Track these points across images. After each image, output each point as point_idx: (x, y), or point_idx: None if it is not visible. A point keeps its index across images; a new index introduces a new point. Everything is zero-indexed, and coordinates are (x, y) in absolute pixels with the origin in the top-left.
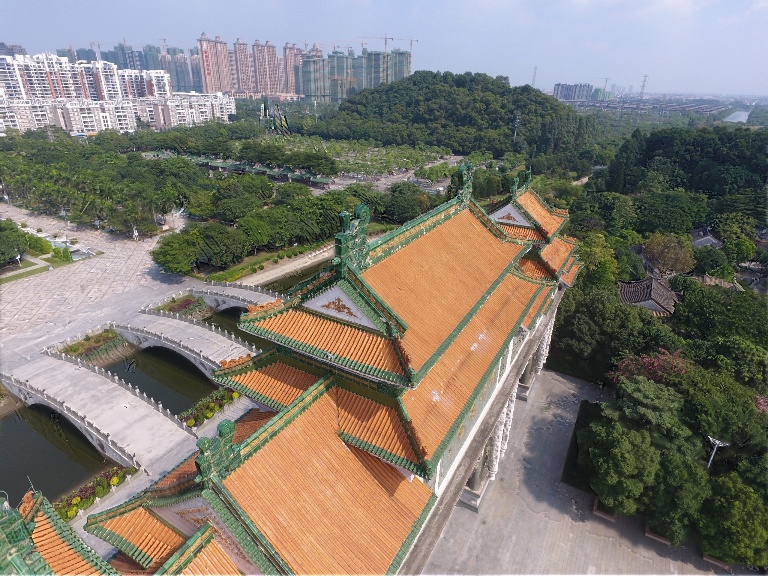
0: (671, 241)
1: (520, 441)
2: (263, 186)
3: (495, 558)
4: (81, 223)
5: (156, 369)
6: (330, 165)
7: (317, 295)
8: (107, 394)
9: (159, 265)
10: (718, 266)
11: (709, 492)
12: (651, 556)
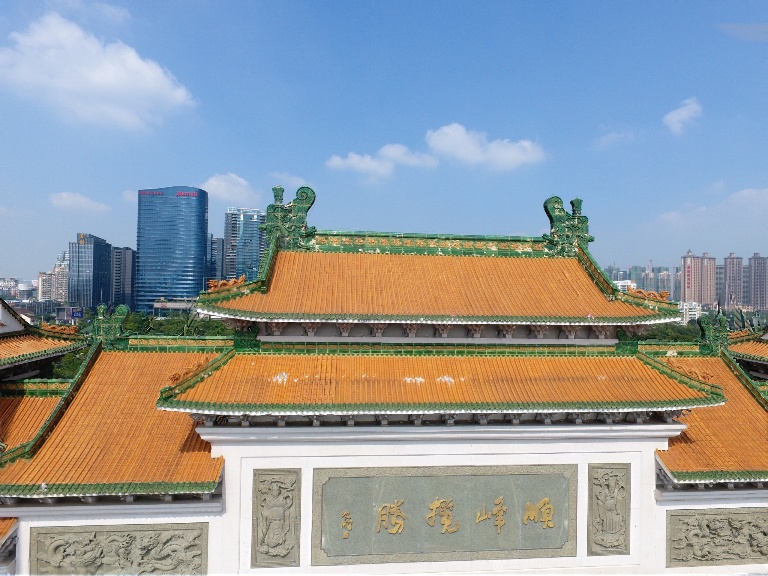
0: None
1: None
2: None
3: None
4: None
5: None
6: None
7: None
8: None
9: None
10: None
11: None
12: None
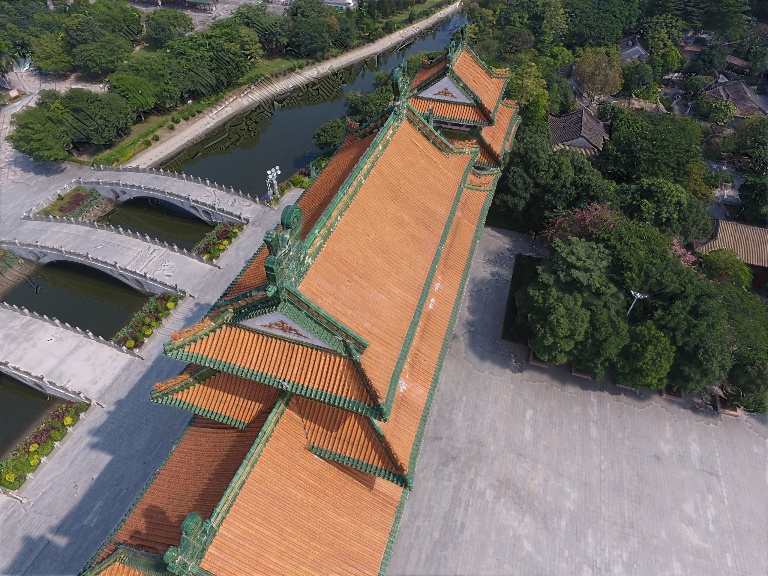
0: (602, 61)
1: (463, 306)
2: (126, 18)
3: (450, 419)
4: None
5: (69, 283)
6: None
7: (254, 317)
8: (22, 330)
9: (25, 154)
10: (644, 85)
11: (628, 340)
12: (576, 391)
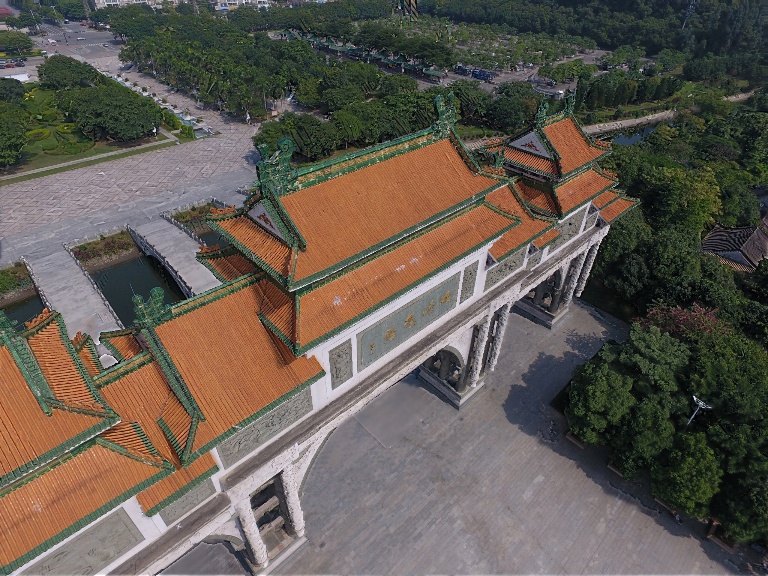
0: None
1: (526, 362)
2: (370, 77)
3: (458, 447)
4: (207, 103)
5: None
6: (446, 56)
7: (253, 208)
8: None
9: None
10: None
11: (669, 444)
12: (603, 483)
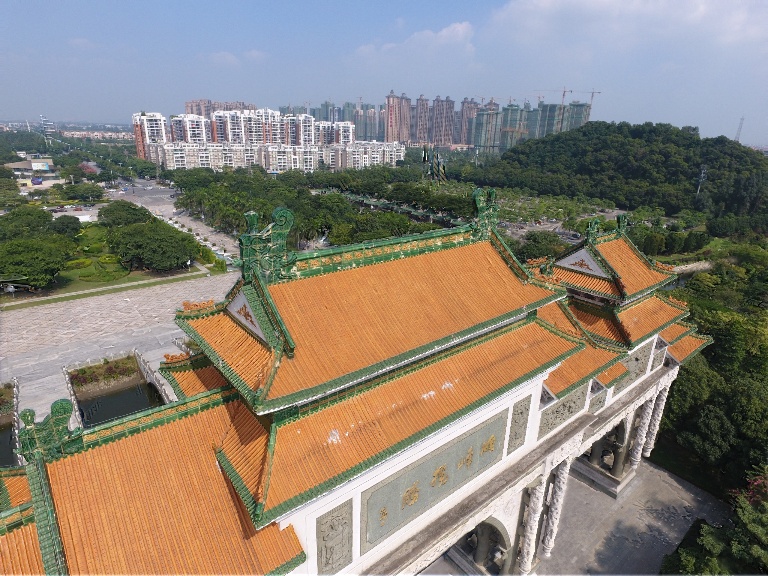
0: None
1: (591, 546)
2: (400, 224)
3: None
4: None
5: None
6: (472, 209)
7: (233, 299)
8: None
9: None
10: None
11: None
12: None
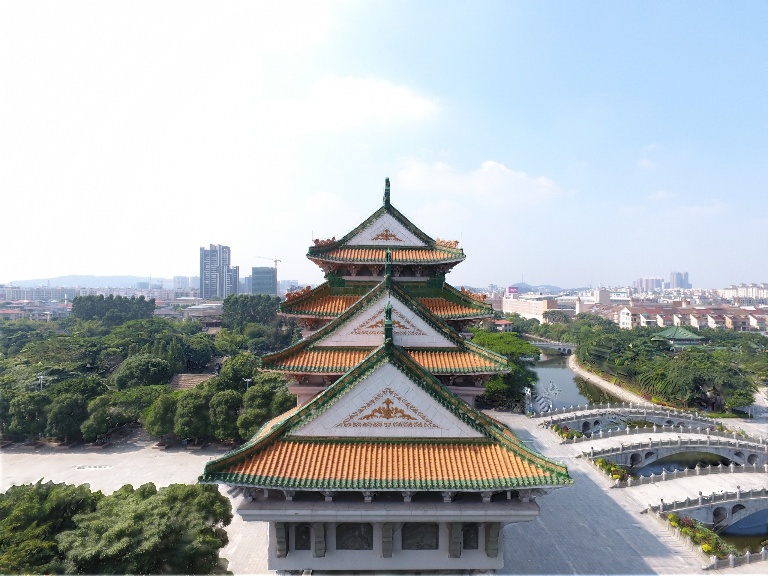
0: None
1: None
2: None
3: None
4: None
5: None
6: None
7: None
8: None
9: None
10: None
11: None
12: None
